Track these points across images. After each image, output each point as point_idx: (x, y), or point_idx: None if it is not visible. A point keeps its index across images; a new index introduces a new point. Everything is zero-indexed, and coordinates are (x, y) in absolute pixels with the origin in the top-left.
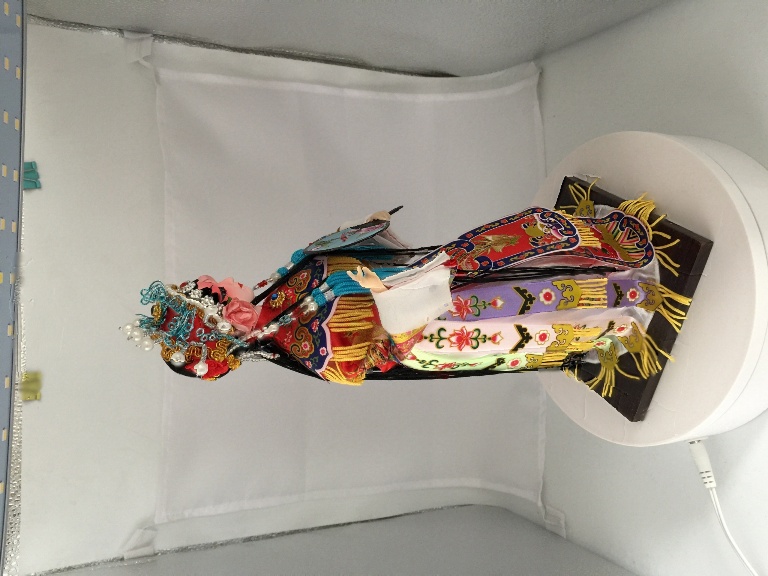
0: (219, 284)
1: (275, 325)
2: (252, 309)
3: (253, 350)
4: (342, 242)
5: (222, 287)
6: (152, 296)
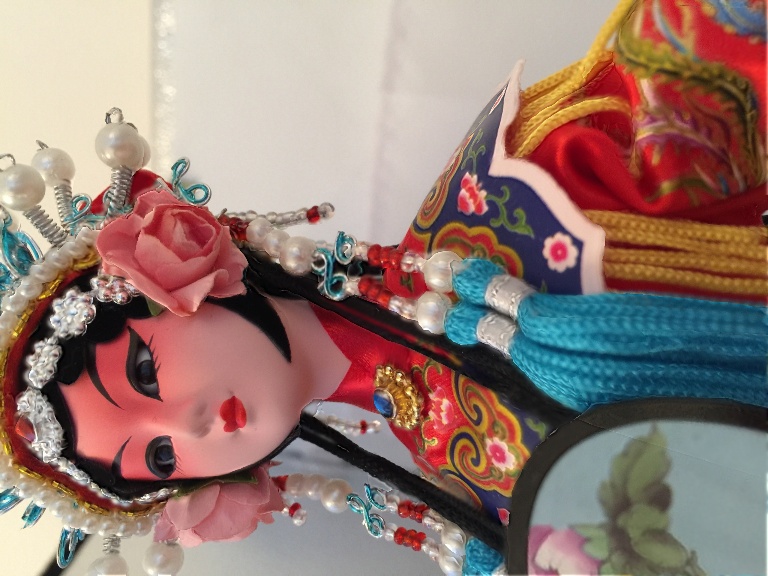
0: (151, 430)
1: (338, 504)
2: (257, 515)
3: None
4: None
5: (164, 437)
6: None
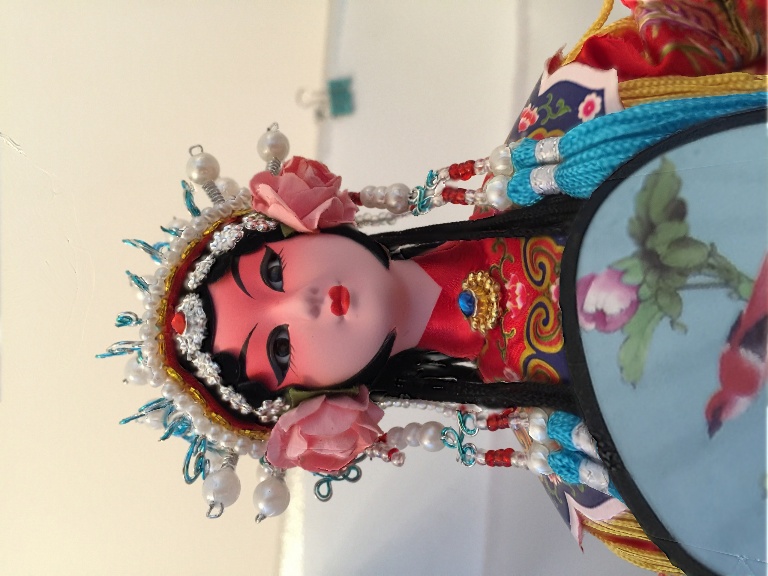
0: (274, 316)
1: (433, 441)
2: (356, 427)
3: (408, 397)
4: (689, 440)
5: (283, 326)
6: (118, 350)
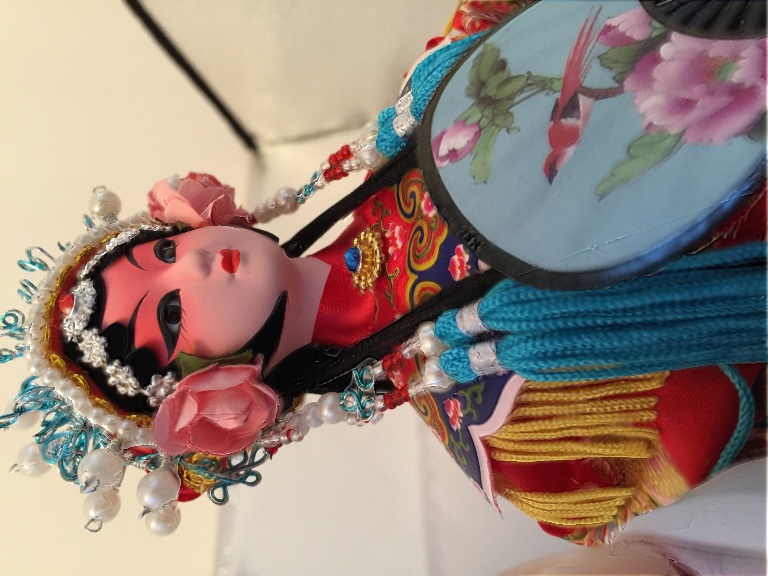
0: (165, 281)
1: (332, 408)
2: (250, 389)
3: None
4: (535, 192)
5: (174, 291)
6: None
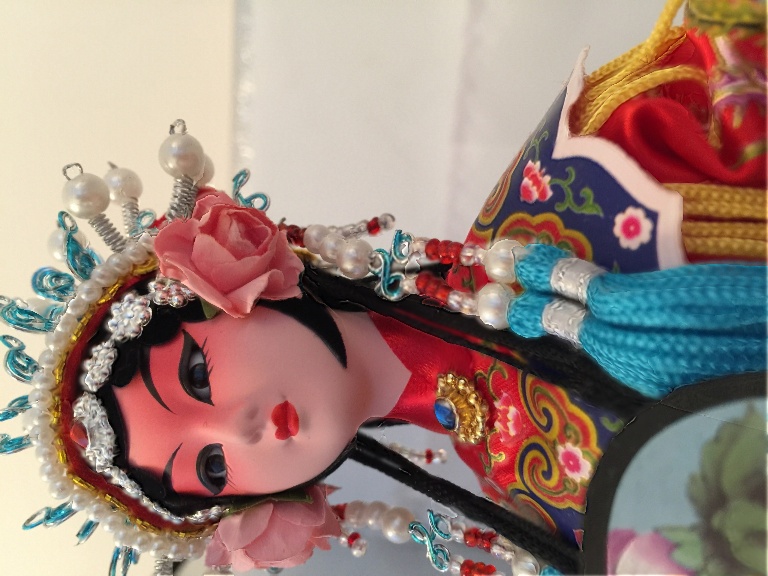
0: (202, 436)
1: (399, 533)
2: (311, 538)
3: None
4: None
5: (215, 444)
6: None
